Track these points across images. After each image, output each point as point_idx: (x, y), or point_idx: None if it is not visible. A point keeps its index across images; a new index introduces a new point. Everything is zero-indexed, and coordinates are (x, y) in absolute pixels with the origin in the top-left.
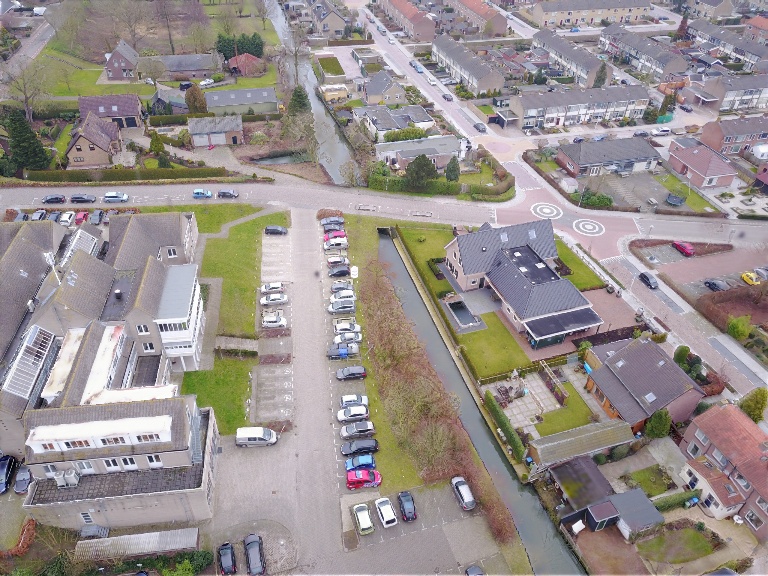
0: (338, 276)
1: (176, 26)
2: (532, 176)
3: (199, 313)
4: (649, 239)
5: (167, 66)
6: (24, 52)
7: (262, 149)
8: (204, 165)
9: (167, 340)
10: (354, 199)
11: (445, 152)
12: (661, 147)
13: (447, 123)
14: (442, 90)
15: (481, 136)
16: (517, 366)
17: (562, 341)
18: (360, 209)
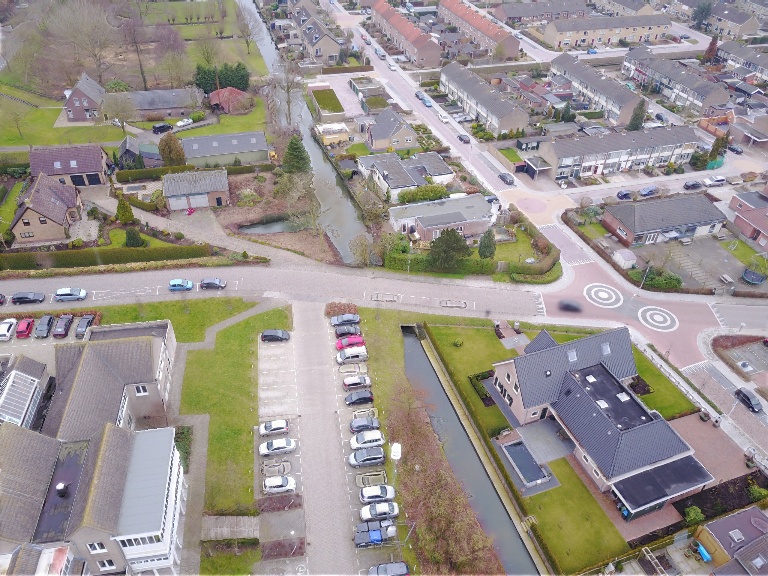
0: (358, 404)
1: (148, 55)
2: (577, 245)
3: (178, 492)
4: (734, 335)
5: (138, 104)
6: None
7: (252, 212)
8: (182, 238)
9: (132, 555)
10: (369, 285)
11: (474, 218)
12: (719, 202)
13: (467, 173)
14: (456, 129)
15: (509, 190)
16: (609, 550)
17: (661, 507)
18: (378, 300)
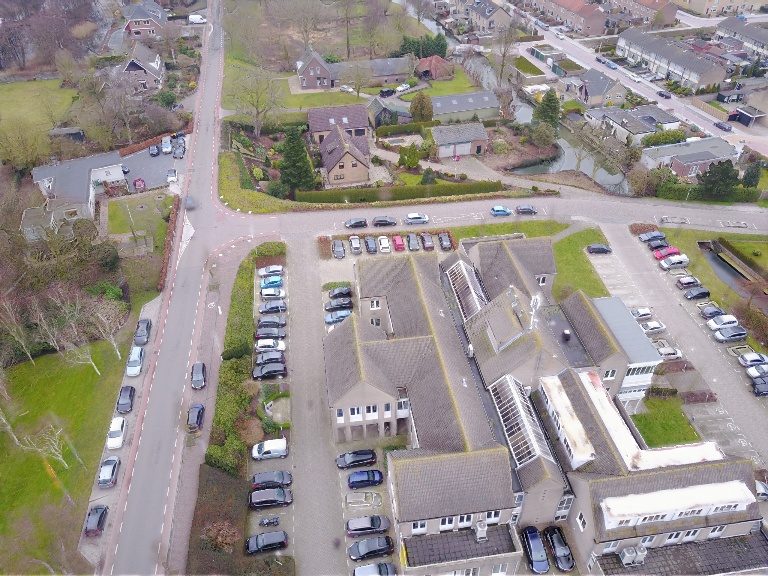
0: (697, 298)
1: (356, 29)
2: None
3: None
4: None
5: None
6: (208, 63)
7: (510, 158)
8: (466, 178)
9: (627, 384)
10: (655, 211)
11: (724, 155)
12: None
13: (683, 123)
14: (651, 87)
15: (730, 136)
16: None
17: None
18: (669, 222)
